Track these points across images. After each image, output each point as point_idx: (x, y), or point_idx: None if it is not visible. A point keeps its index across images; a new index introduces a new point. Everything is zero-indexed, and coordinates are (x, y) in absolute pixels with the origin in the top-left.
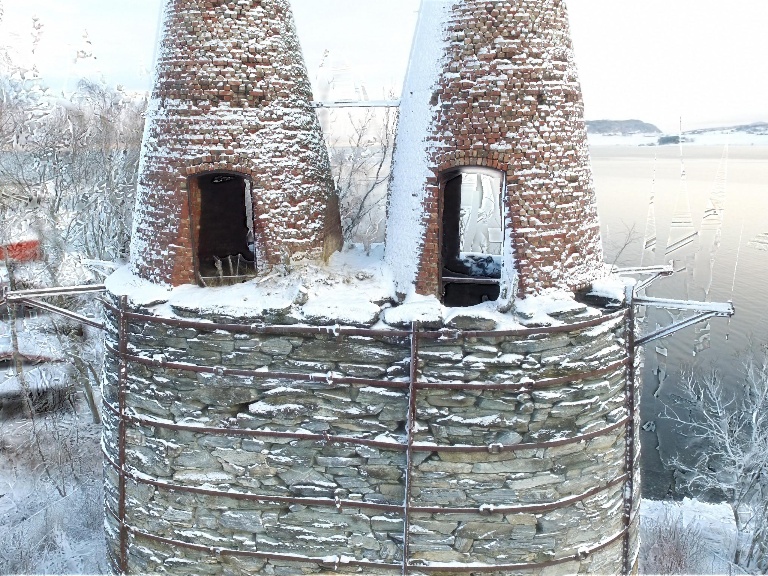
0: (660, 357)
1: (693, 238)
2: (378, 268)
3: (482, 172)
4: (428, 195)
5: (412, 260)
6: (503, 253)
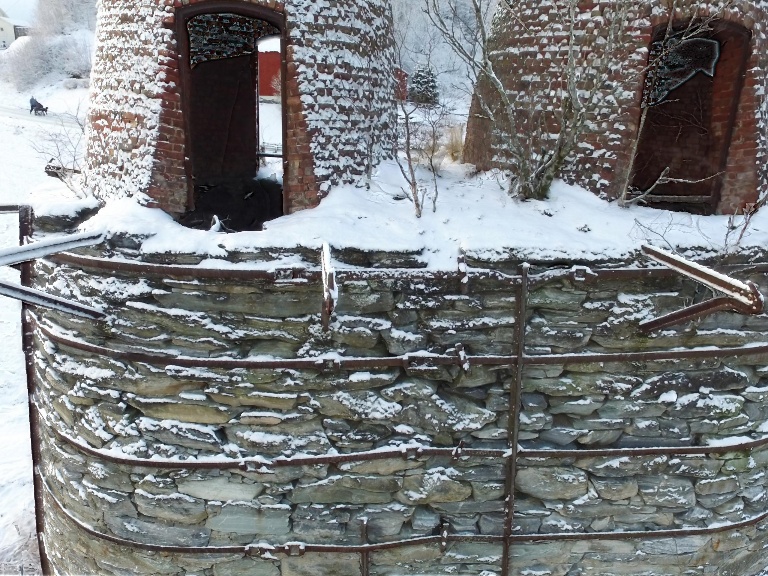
0: None
1: None
2: None
3: (278, 40)
4: None
5: None
6: None
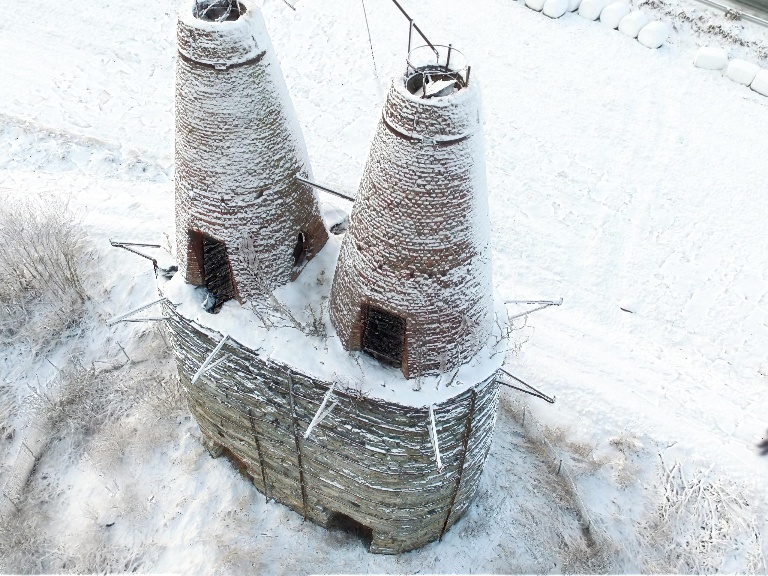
0: None
1: None
2: (335, 238)
3: None
4: None
5: None
6: None
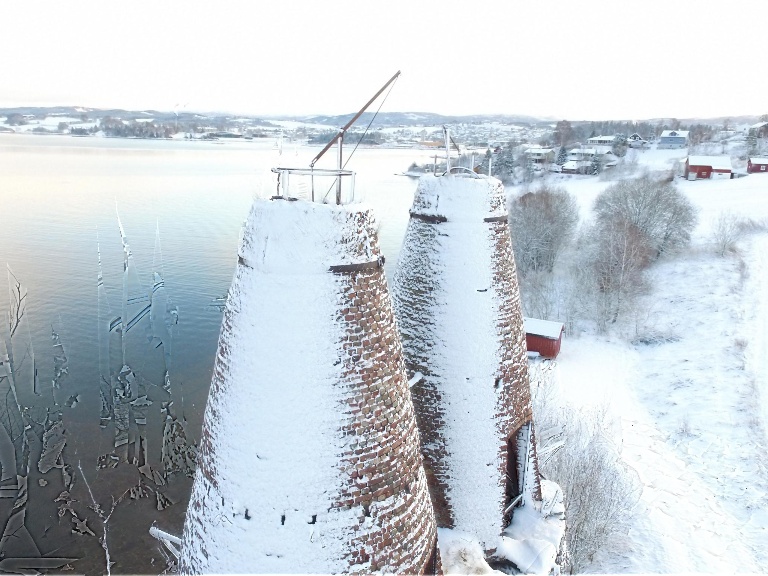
0: (142, 427)
1: (147, 310)
2: (461, 540)
3: None
4: (503, 461)
5: (498, 518)
6: (527, 476)
